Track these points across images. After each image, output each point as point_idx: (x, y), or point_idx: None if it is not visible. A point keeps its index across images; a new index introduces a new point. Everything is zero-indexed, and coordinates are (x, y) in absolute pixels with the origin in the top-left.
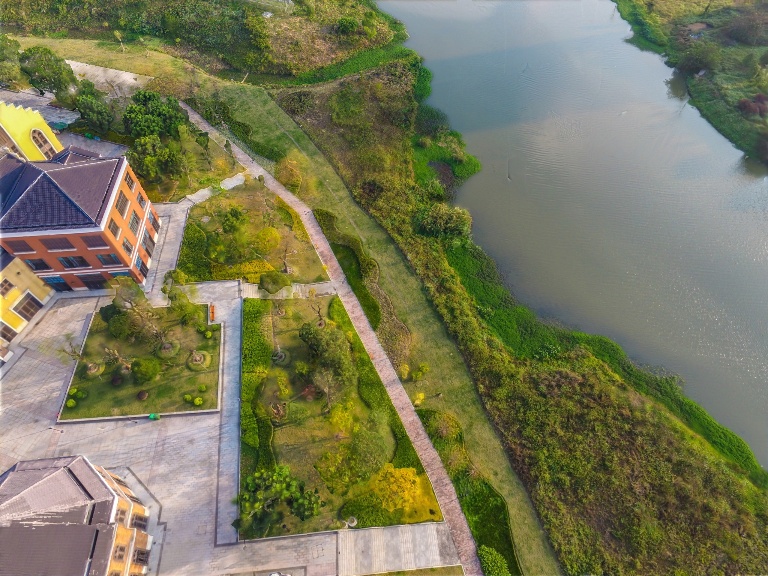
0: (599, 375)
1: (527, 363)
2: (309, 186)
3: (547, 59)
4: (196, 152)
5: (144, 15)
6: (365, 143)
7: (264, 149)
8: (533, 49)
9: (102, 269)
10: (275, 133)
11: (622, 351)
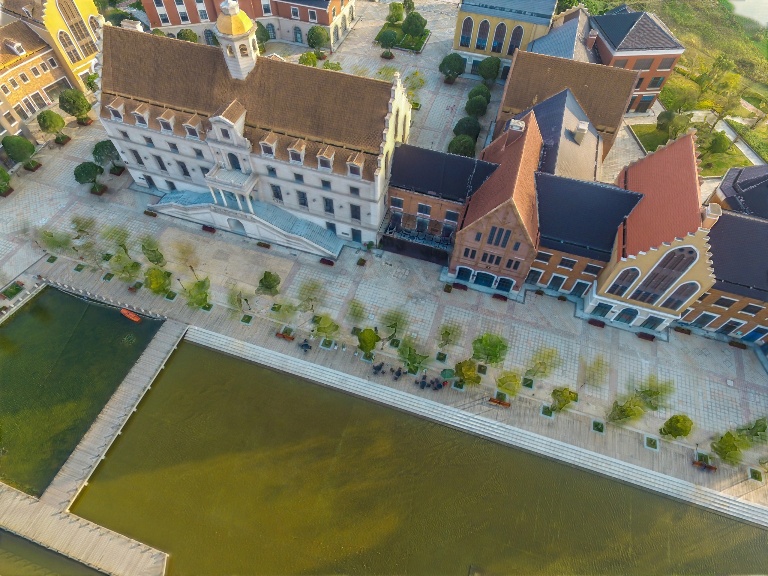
0: None
1: None
2: None
3: None
4: None
5: None
6: (715, 37)
7: None
8: None
9: (642, 92)
10: None
11: None
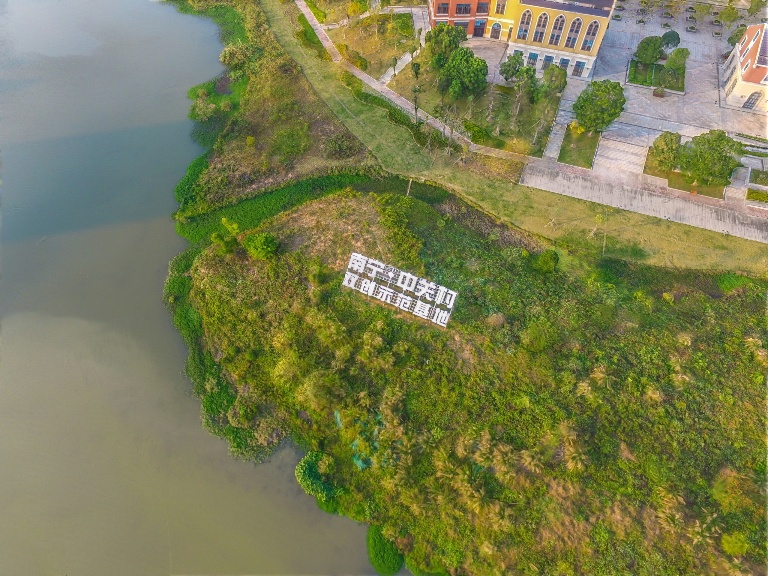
0: (198, 0)
1: (230, 4)
2: (334, 75)
3: (1, 220)
4: (430, 91)
5: (610, 302)
6: None
7: (373, 100)
8: (2, 237)
9: None
10: (365, 116)
11: (178, 8)
